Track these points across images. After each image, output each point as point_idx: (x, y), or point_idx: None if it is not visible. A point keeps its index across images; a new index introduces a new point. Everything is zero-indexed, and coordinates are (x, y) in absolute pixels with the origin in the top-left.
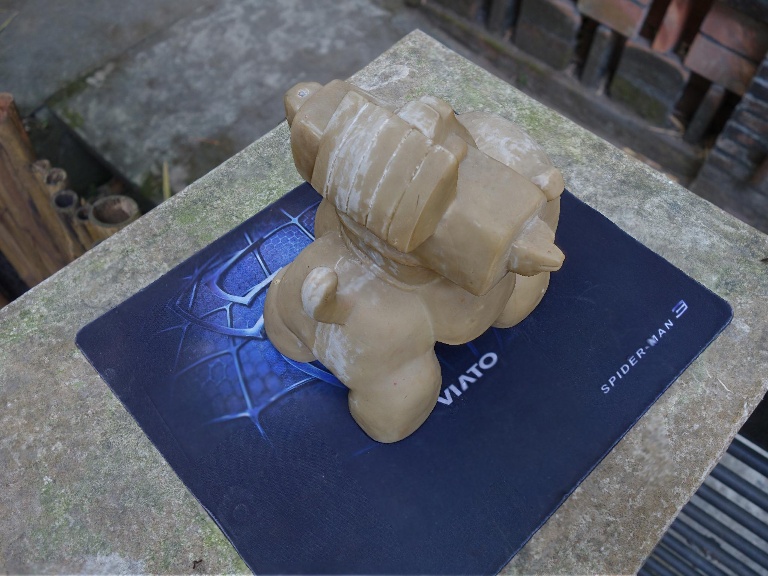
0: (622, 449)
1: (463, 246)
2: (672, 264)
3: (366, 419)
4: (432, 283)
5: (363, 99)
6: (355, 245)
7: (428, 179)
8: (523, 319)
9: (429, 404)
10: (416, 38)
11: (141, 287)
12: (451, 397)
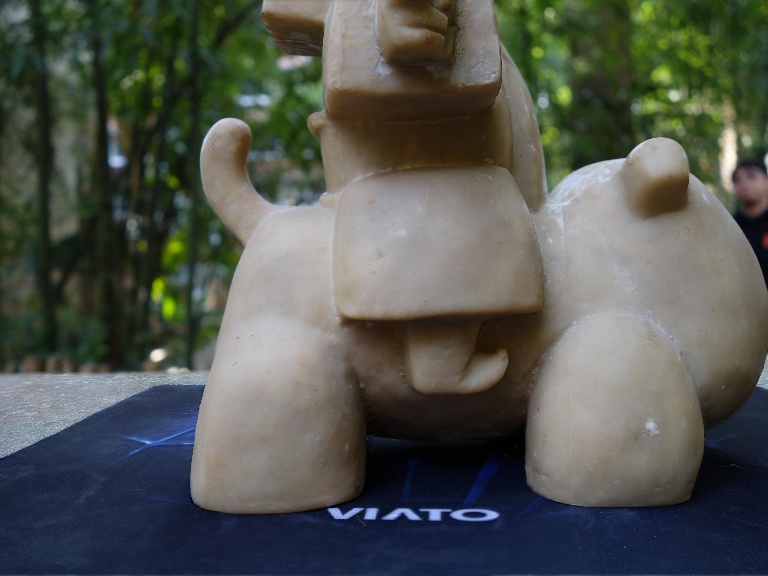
0: None
1: None
2: None
3: None
4: (352, 183)
5: None
6: None
7: None
8: (607, 501)
9: (276, 435)
10: None
11: None
12: (353, 515)
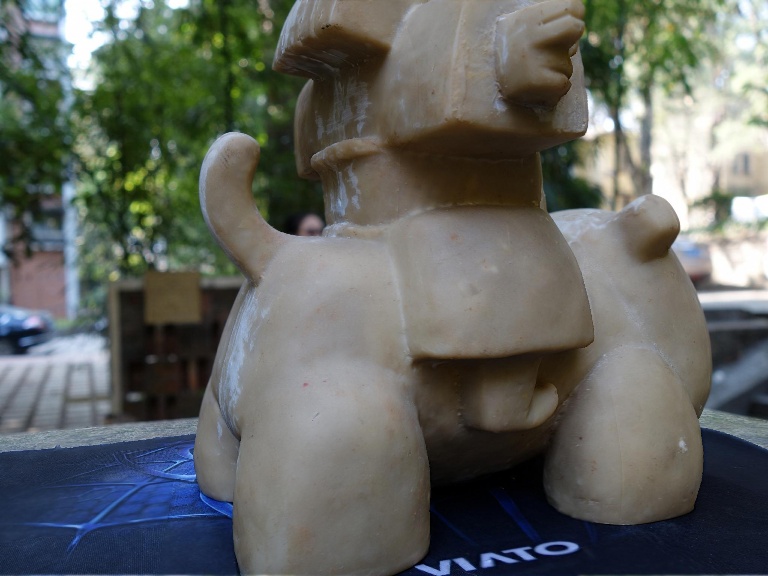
0: None
1: (422, 36)
2: None
3: (241, 497)
4: (409, 216)
5: None
6: None
7: None
8: (651, 517)
9: (374, 492)
10: None
11: None
12: (450, 569)
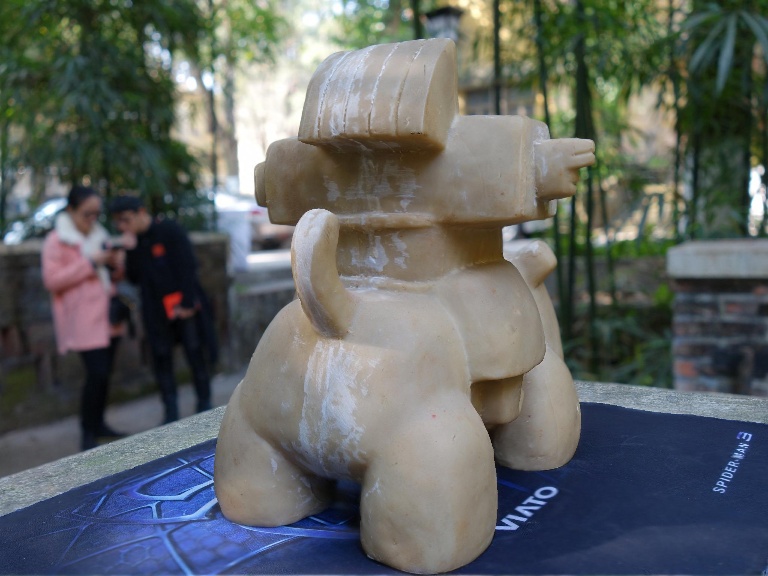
0: None
1: (482, 147)
2: (705, 417)
3: (398, 512)
4: (451, 274)
5: None
6: (346, 275)
7: (430, 53)
8: (568, 459)
9: (489, 483)
10: None
11: None
12: (514, 523)
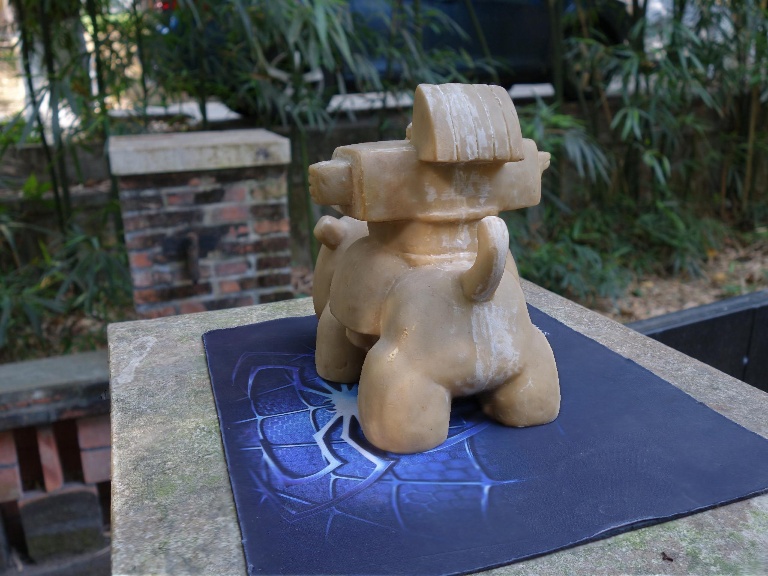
0: None
1: (522, 161)
2: None
3: (543, 392)
4: None
5: None
6: (435, 254)
7: (506, 100)
8: None
9: None
10: (120, 326)
11: (234, 546)
12: None
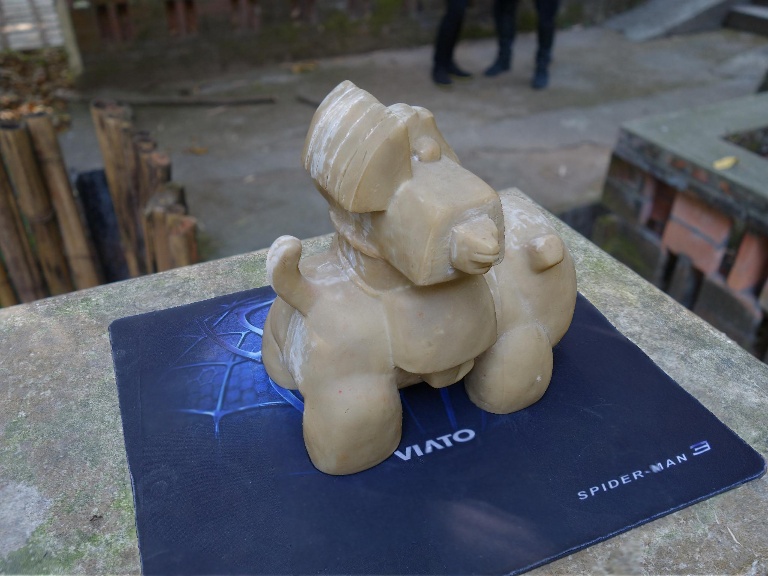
0: (581, 559)
1: (407, 223)
2: (705, 407)
3: (310, 434)
4: (395, 290)
5: (352, 85)
6: (343, 253)
7: (377, 138)
8: (516, 410)
9: (376, 437)
10: (511, 193)
11: (185, 304)
12: (410, 455)
